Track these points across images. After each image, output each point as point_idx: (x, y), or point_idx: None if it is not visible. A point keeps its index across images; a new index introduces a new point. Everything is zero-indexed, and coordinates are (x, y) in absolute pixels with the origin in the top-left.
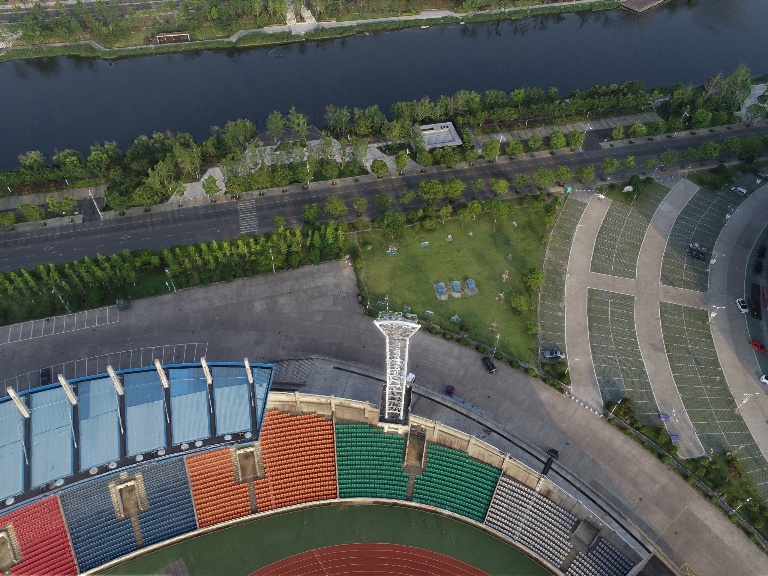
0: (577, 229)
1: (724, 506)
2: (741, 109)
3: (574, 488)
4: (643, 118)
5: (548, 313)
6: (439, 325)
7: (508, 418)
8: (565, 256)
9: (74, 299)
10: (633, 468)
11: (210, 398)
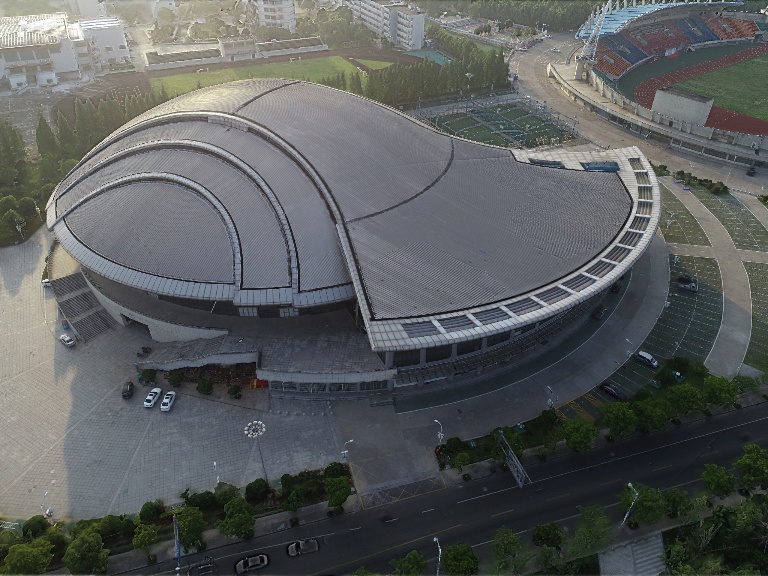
0: None
1: None
2: None
3: None
4: None
5: None
6: None
7: None
8: None
9: None
10: (699, 172)
11: None
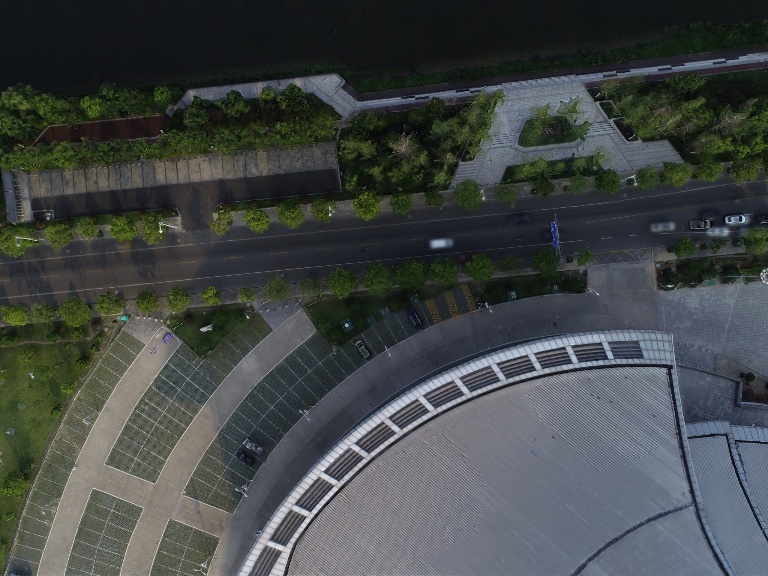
0: (114, 391)
1: None
2: (478, 153)
3: None
4: (308, 157)
5: (33, 520)
6: None
7: None
8: (82, 436)
9: None
10: None
11: None
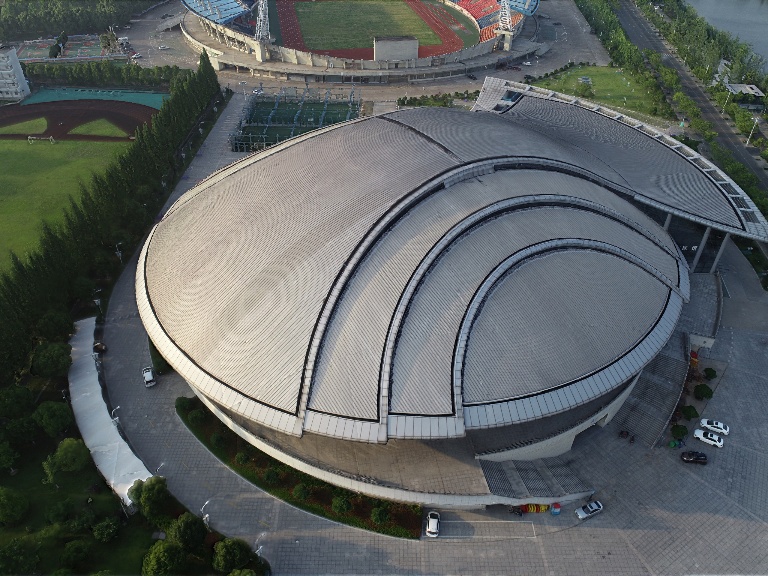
0: None
1: None
2: None
3: None
4: None
5: None
6: None
7: None
8: None
9: (596, 23)
10: (457, 90)
11: (519, 2)
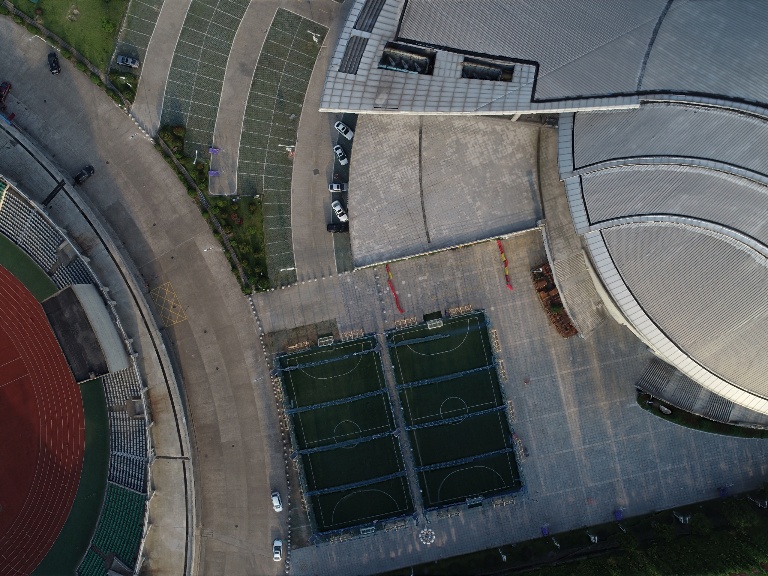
0: None
1: (226, 242)
2: None
3: (77, 210)
4: None
5: (142, 5)
6: (13, 3)
7: (58, 127)
8: None
9: None
10: (160, 196)
11: None
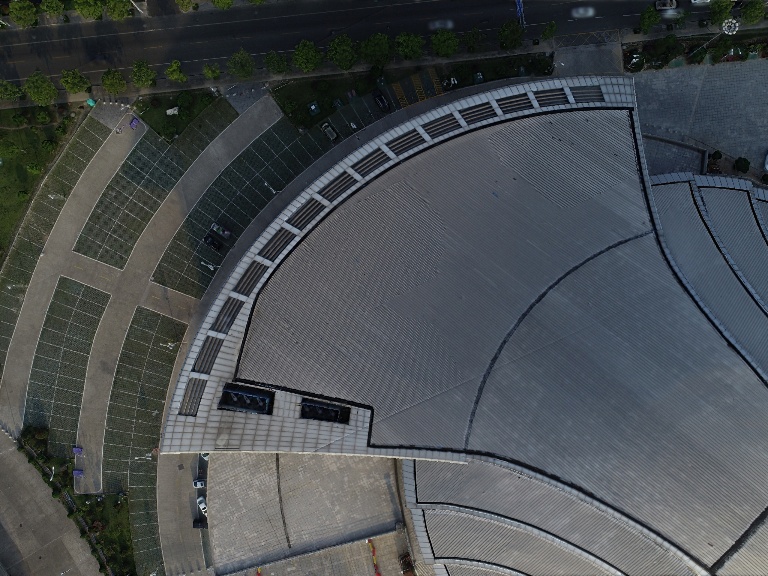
0: (81, 177)
1: (94, 541)
2: None
3: None
4: None
5: (1, 308)
6: None
7: None
8: (49, 222)
9: None
10: (25, 497)
11: None
